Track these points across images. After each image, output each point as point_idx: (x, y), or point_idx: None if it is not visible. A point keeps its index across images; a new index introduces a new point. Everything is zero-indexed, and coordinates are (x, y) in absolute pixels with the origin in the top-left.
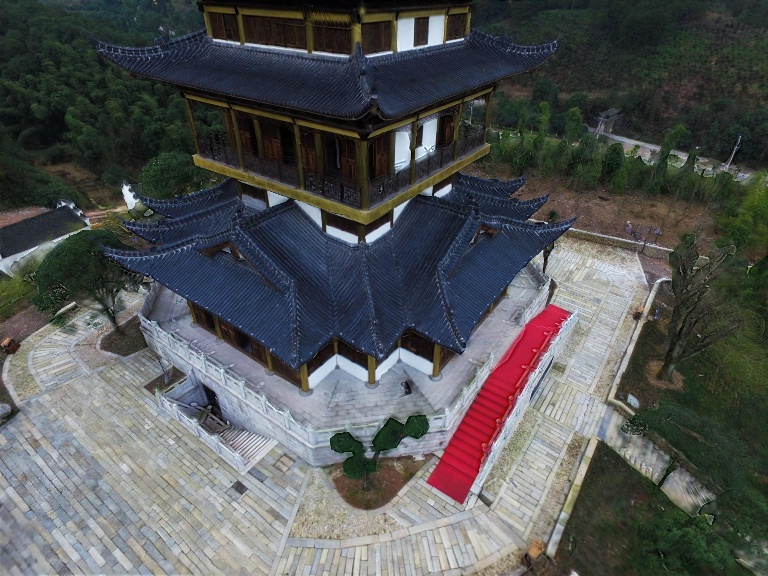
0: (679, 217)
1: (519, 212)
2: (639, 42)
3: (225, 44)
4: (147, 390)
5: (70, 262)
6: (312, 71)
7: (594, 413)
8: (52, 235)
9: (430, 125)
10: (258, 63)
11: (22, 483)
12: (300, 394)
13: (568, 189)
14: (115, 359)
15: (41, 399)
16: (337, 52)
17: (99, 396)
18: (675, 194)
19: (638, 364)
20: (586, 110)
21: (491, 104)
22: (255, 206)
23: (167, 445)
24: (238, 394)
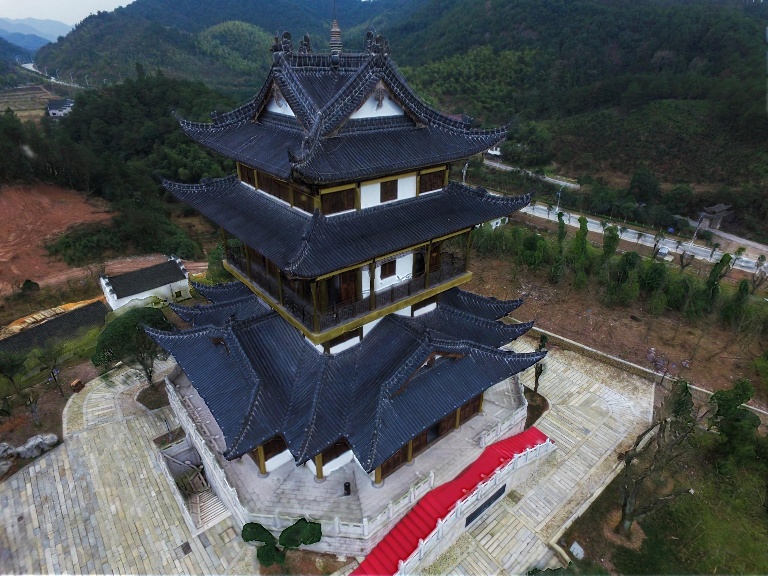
0: (716, 351)
1: (503, 334)
2: (761, 136)
3: (247, 187)
4: (154, 443)
5: (120, 333)
6: (288, 222)
7: (531, 554)
8: (158, 284)
9: (404, 258)
10: (260, 208)
11: (42, 503)
12: (258, 475)
13: (600, 304)
14: (143, 411)
15: (81, 435)
16: (307, 211)
17: (119, 441)
18: (703, 328)
19: (598, 511)
20: (691, 203)
21: (584, 190)
22: (265, 304)
23: (149, 496)
24: (211, 464)
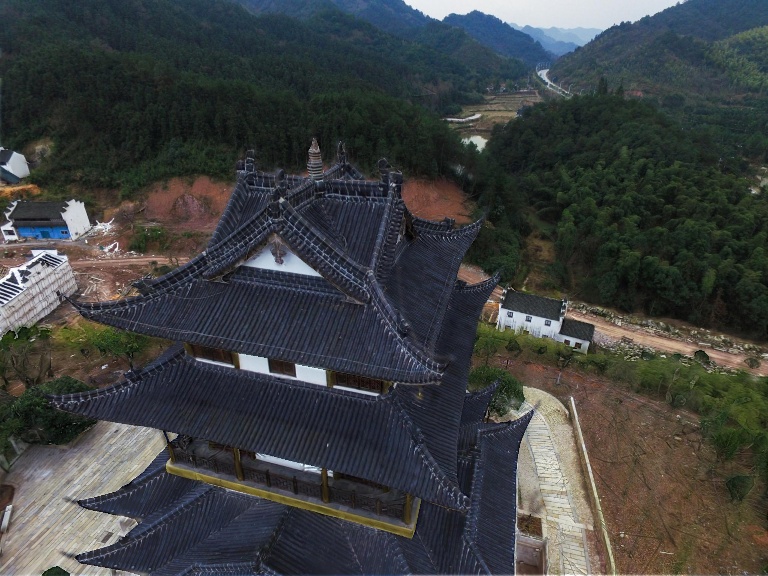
0: None
1: None
2: None
3: None
4: None
5: None
6: None
7: None
8: None
9: None
10: None
11: (130, 430)
12: None
13: None
14: None
15: None
16: None
17: None
18: None
19: None
20: None
21: None
22: None
23: None
24: None
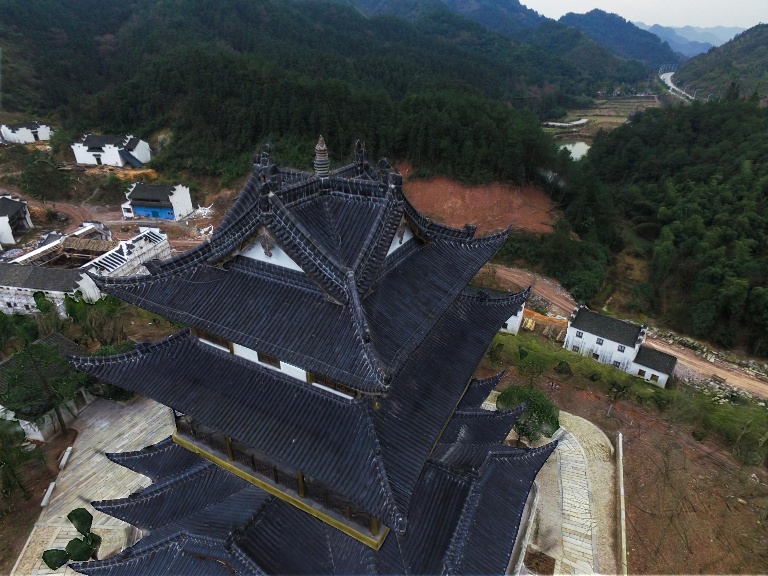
0: None
1: None
2: None
3: None
4: None
5: None
6: None
7: None
8: None
9: None
10: None
11: None
12: None
13: None
14: None
15: None
16: None
17: None
18: None
19: None
20: None
21: None
22: None
23: None
24: None
